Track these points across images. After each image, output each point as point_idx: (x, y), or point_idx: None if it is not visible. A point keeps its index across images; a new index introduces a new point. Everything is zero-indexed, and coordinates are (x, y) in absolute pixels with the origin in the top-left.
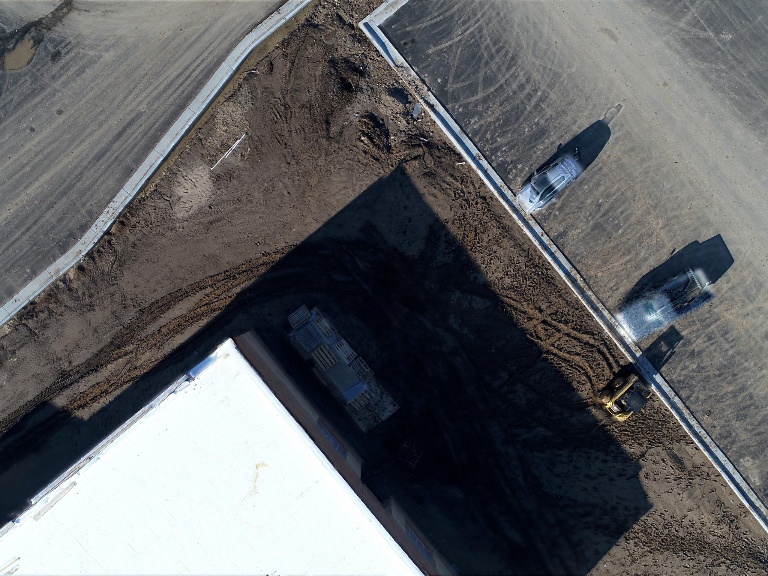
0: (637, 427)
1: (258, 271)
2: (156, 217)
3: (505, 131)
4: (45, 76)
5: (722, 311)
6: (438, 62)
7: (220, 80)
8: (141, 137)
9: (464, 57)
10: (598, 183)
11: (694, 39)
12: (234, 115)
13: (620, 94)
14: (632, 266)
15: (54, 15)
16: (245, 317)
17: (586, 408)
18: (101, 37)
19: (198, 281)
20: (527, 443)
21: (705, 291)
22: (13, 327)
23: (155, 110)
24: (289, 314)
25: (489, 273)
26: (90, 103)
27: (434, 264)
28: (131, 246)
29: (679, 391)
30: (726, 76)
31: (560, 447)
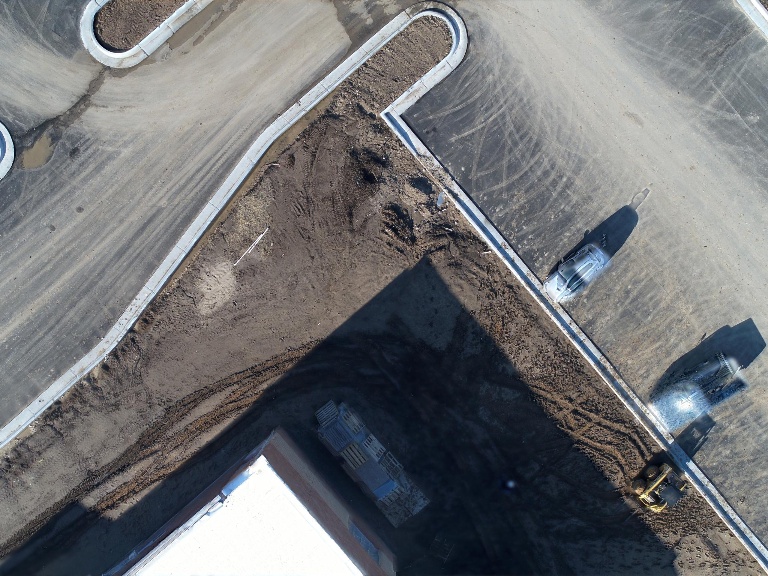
0: (670, 515)
1: (284, 367)
2: (180, 314)
3: (531, 219)
4: (64, 174)
5: (755, 395)
6: (461, 150)
7: (241, 174)
8: (163, 233)
9: (488, 145)
10: (626, 269)
11: (721, 121)
12: (256, 210)
13: (647, 178)
14: (662, 352)
15: (72, 112)
16: (272, 414)
17: (618, 497)
18: (120, 133)
19: (223, 378)
20: (559, 534)
21: (737, 376)
22: (38, 428)
23: (176, 206)
24: (316, 410)
25: (517, 363)
26: (110, 200)
27: (462, 356)
28: (155, 344)
29: (712, 477)
30: (755, 158)
31: (593, 537)
